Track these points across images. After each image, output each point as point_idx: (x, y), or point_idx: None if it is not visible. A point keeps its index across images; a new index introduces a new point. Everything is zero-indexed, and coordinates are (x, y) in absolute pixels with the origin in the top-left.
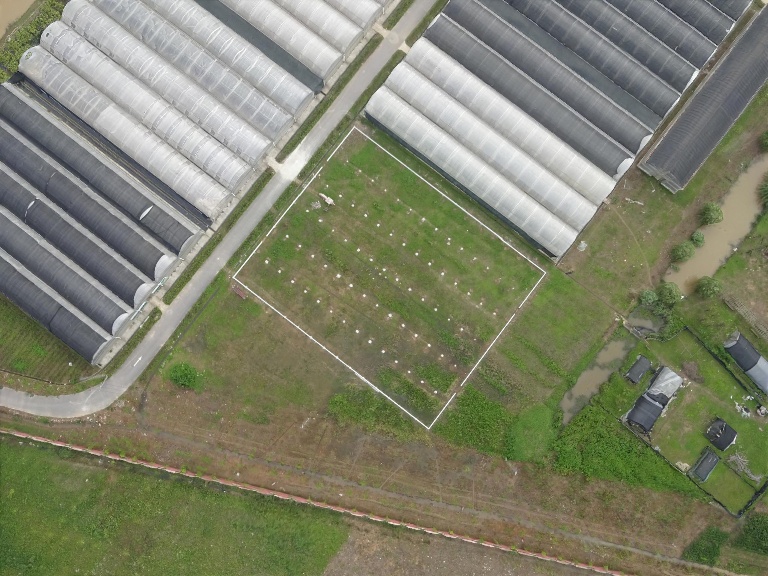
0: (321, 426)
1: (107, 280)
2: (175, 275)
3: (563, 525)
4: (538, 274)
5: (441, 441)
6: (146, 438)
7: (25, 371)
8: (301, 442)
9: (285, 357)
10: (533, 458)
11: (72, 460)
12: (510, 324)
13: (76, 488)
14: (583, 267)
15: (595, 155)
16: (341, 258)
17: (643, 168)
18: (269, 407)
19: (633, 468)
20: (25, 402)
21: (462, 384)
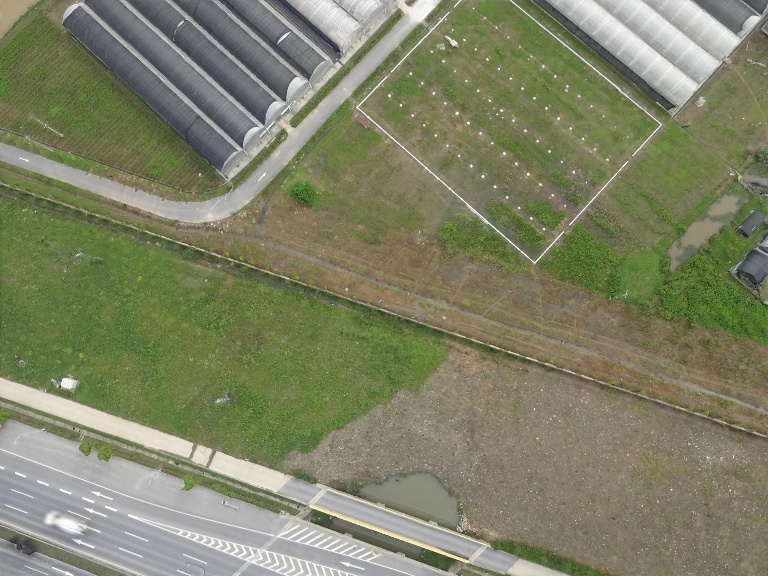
0: (430, 251)
1: (243, 96)
2: (303, 102)
3: (664, 369)
4: (654, 125)
5: (546, 276)
6: (263, 248)
7: (159, 178)
8: (409, 265)
9: (400, 184)
10: (638, 300)
11: (194, 261)
12: (622, 171)
13: (196, 286)
14: (700, 122)
15: (721, 11)
16: (461, 97)
17: (767, 31)
18: (381, 229)
19: (740, 319)
20: (156, 205)
21: (571, 224)
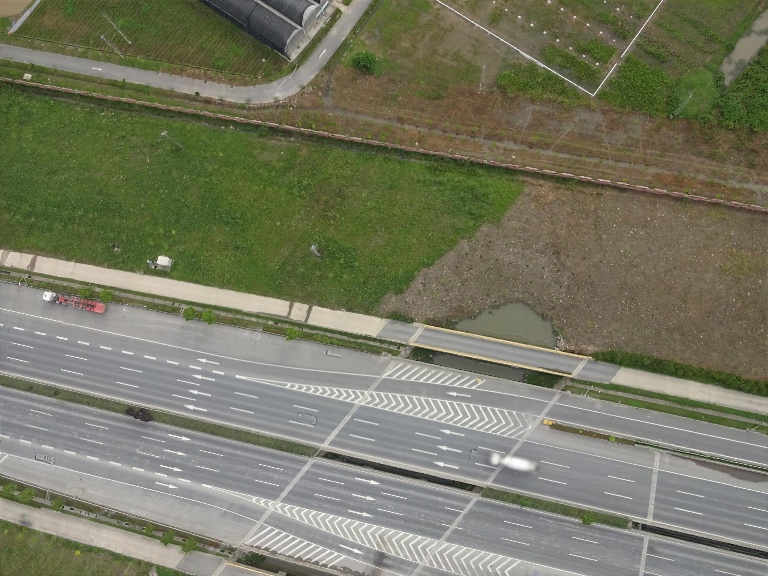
0: (491, 99)
1: None
2: None
3: (733, 175)
4: None
5: (606, 106)
6: (332, 117)
7: (225, 68)
8: (473, 114)
9: (454, 43)
10: (698, 114)
11: (268, 138)
12: (664, 2)
13: (273, 158)
14: None
15: None
16: None
17: None
18: (442, 85)
19: None
20: (226, 92)
21: (622, 56)
